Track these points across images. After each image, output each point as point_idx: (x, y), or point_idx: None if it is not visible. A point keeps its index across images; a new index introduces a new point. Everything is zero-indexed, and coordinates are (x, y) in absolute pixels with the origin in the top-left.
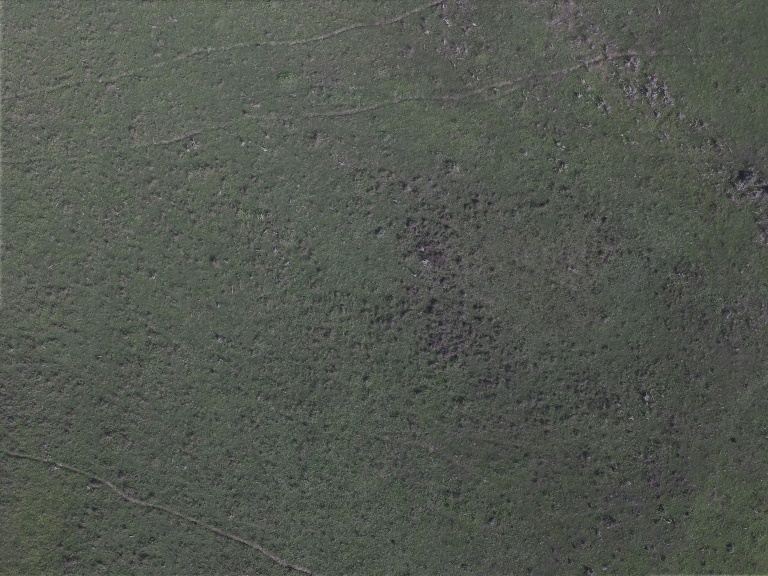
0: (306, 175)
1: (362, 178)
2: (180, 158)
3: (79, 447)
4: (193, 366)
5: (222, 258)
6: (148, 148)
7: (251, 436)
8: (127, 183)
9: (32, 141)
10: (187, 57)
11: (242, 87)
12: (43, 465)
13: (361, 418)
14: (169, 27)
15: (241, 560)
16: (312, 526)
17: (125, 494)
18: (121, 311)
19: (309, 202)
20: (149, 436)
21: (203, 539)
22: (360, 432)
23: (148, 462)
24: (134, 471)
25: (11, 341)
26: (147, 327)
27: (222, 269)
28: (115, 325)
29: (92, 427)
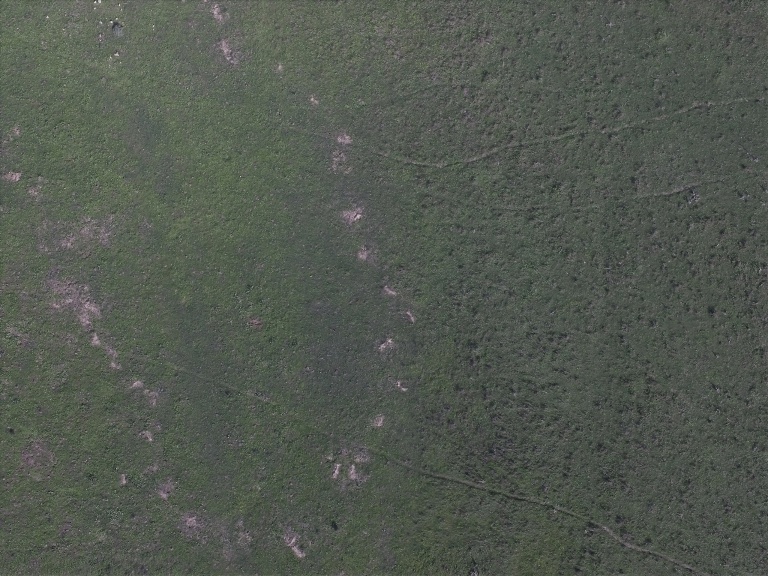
0: None
1: None
2: (680, 210)
3: (576, 491)
4: (690, 415)
5: (720, 310)
6: (650, 199)
7: (746, 486)
8: (629, 233)
9: (536, 189)
10: (688, 111)
11: (740, 141)
12: (541, 508)
13: None
14: (671, 81)
15: None
16: None
17: (622, 539)
18: (621, 359)
19: None
20: (647, 483)
21: None
22: None
23: (645, 508)
24: (631, 517)
25: (513, 385)
26: (647, 375)
27: (719, 320)
28: (614, 372)
29: (589, 472)
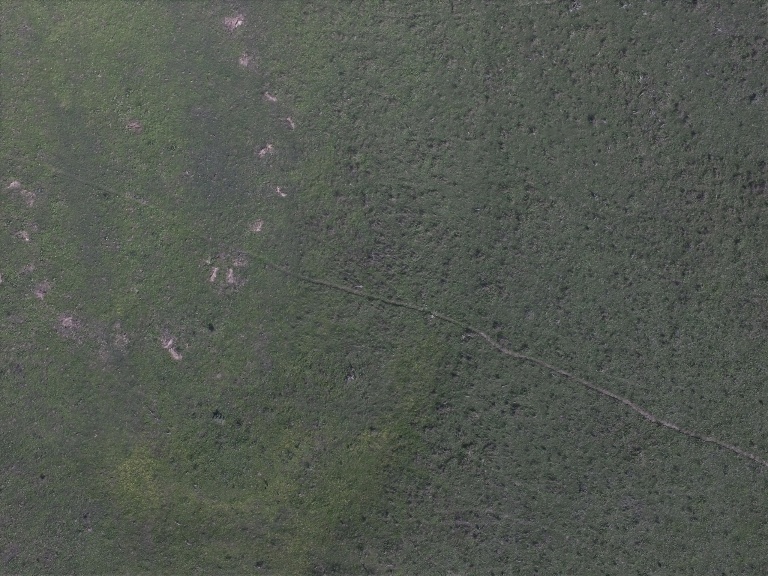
0: (683, 40)
1: (738, 45)
2: (561, 18)
3: (454, 297)
4: (568, 222)
5: (600, 118)
6: (531, 7)
7: (624, 293)
8: (510, 41)
9: None
10: None
11: None
12: (419, 313)
13: (732, 280)
14: None
15: (611, 414)
16: (682, 383)
17: (499, 345)
18: (500, 166)
19: (685, 66)
20: (524, 289)
21: (573, 392)
22: (730, 294)
23: (522, 314)
24: (508, 323)
25: (392, 191)
26: (526, 182)
27: (599, 129)
28: (493, 179)
29: (467, 278)
